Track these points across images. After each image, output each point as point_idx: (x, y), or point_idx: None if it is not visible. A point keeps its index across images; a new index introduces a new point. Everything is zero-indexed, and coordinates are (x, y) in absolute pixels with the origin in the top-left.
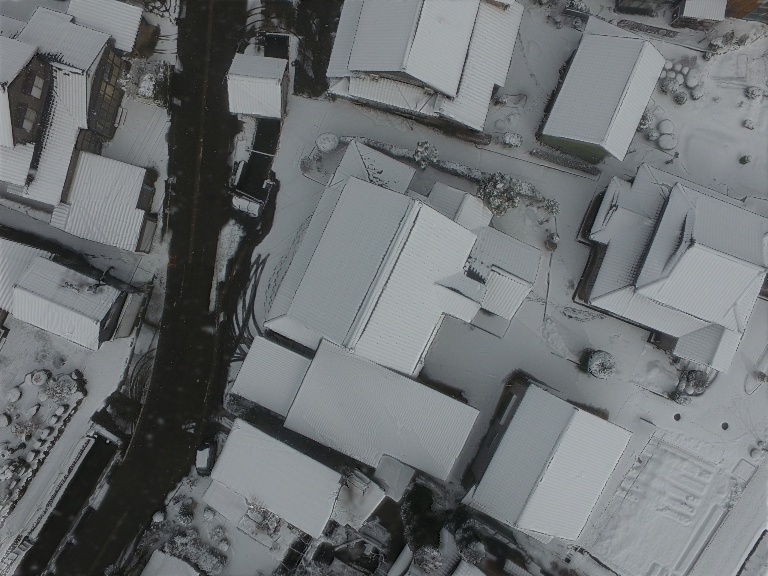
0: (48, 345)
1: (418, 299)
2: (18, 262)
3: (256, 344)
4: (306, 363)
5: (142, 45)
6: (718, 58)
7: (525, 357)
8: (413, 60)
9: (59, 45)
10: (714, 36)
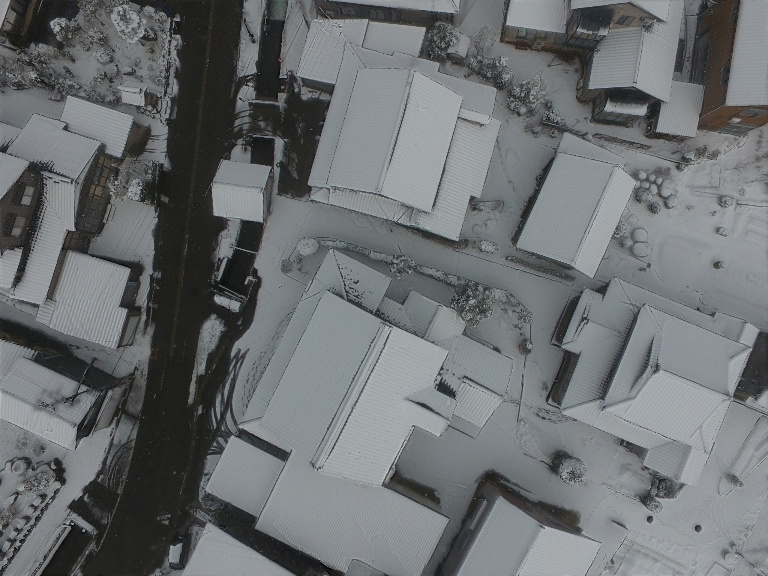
0: (29, 433)
1: (388, 415)
2: (2, 359)
3: (231, 444)
4: (280, 465)
5: (133, 144)
6: (692, 168)
7: (498, 458)
8: (389, 183)
9: (51, 153)
10: (687, 150)
